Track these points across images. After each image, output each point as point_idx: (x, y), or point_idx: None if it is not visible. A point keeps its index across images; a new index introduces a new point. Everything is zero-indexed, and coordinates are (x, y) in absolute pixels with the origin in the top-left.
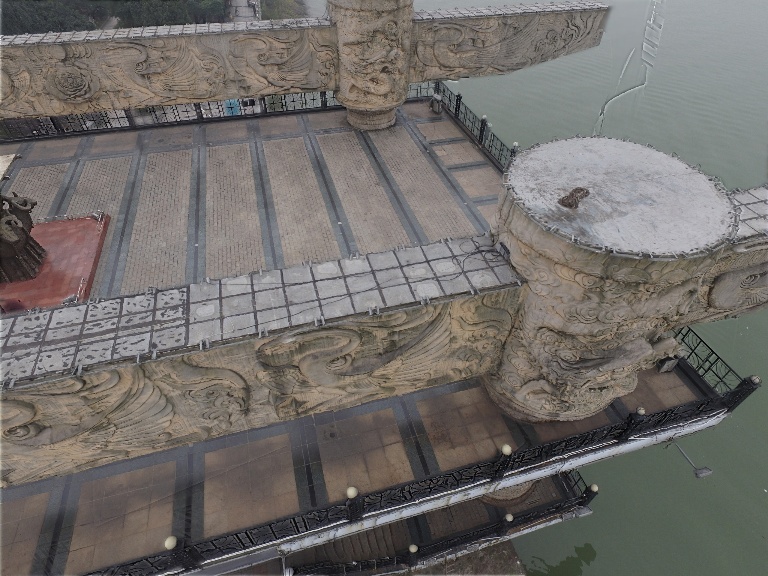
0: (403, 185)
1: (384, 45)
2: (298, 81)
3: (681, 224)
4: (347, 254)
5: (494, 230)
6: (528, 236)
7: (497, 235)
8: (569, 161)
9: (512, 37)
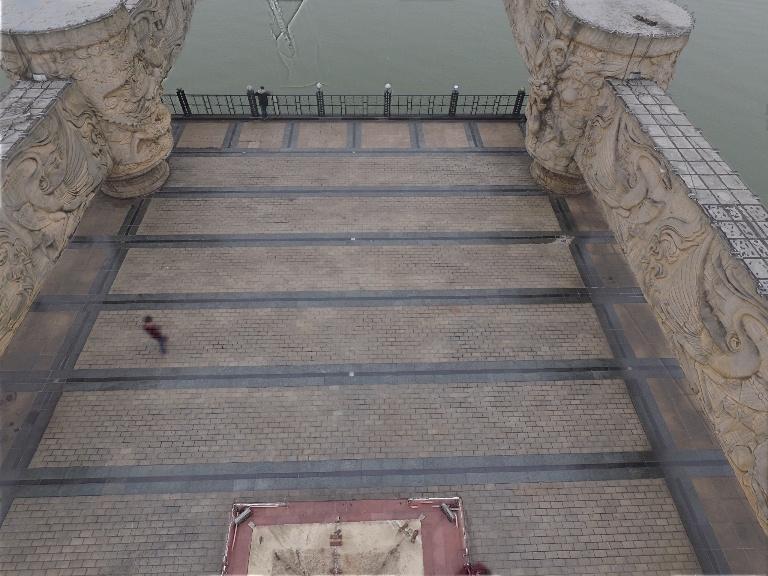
0: (303, 182)
1: (142, 70)
2: (85, 184)
3: (663, 6)
4: (407, 241)
5: (620, 71)
6: (665, 49)
7: (625, 71)
8: (598, 13)
9: (170, 4)
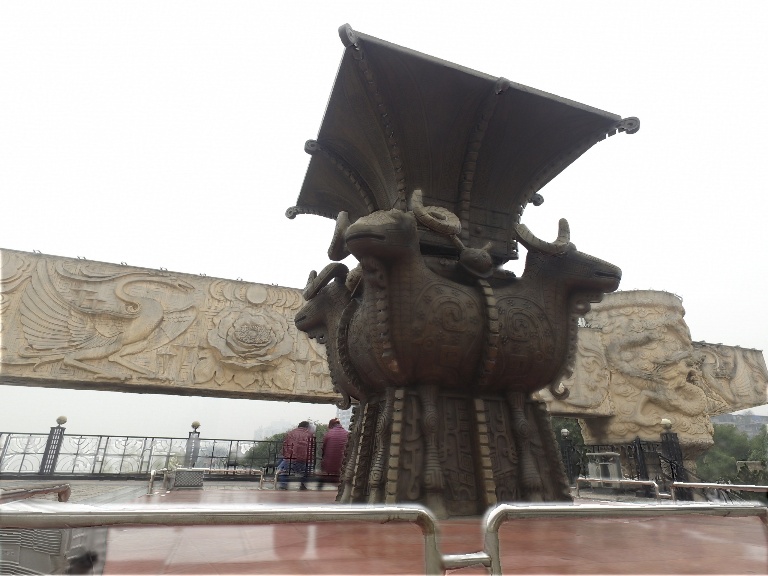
0: None
1: None
2: None
3: None
4: None
5: None
6: None
7: None
8: None
9: None
